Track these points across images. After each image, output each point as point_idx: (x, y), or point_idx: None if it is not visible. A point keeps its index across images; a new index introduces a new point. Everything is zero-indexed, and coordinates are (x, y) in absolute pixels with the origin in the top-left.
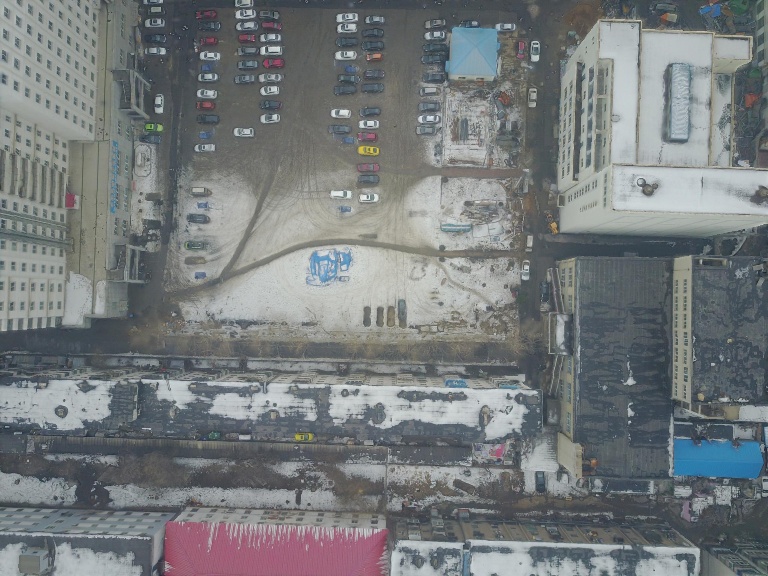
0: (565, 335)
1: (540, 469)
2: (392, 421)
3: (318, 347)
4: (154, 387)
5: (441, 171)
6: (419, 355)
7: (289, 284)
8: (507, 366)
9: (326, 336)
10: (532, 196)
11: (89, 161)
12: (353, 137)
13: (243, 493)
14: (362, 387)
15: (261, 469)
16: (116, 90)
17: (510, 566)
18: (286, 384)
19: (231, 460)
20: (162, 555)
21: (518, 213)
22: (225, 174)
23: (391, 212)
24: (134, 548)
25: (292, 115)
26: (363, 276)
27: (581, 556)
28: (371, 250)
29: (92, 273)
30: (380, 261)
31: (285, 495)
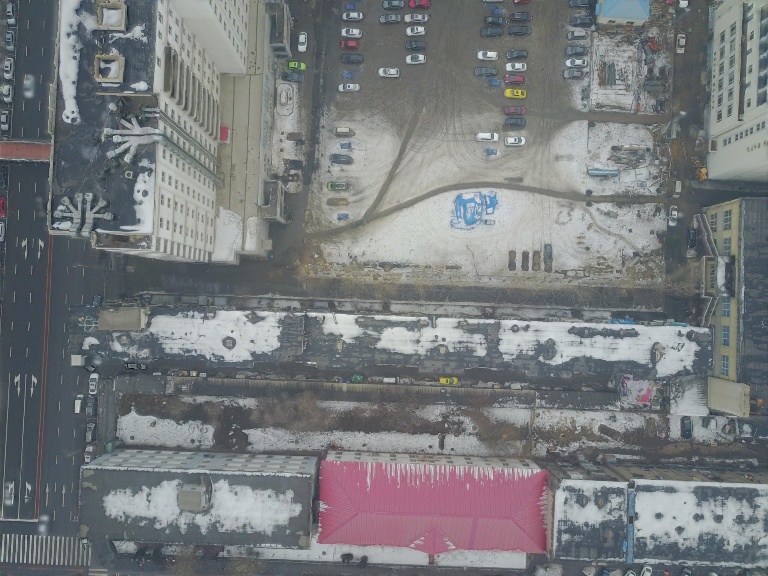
0: (726, 276)
1: (690, 413)
2: (563, 357)
3: (462, 291)
4: (320, 320)
5: (588, 115)
6: (564, 300)
7: (433, 227)
8: (653, 312)
9: (471, 280)
10: (679, 142)
11: (240, 95)
12: (499, 80)
13: (385, 437)
14: (532, 323)
15: (404, 413)
16: (269, 23)
17: (674, 505)
18: (455, 319)
19: (373, 404)
20: (314, 495)
21: (666, 159)
22: (369, 115)
23: (537, 156)
24: (293, 486)
25: (438, 56)
26: (508, 220)
27: (745, 496)
28: (517, 194)
29: (242, 209)
30: (526, 205)
31: (428, 440)
